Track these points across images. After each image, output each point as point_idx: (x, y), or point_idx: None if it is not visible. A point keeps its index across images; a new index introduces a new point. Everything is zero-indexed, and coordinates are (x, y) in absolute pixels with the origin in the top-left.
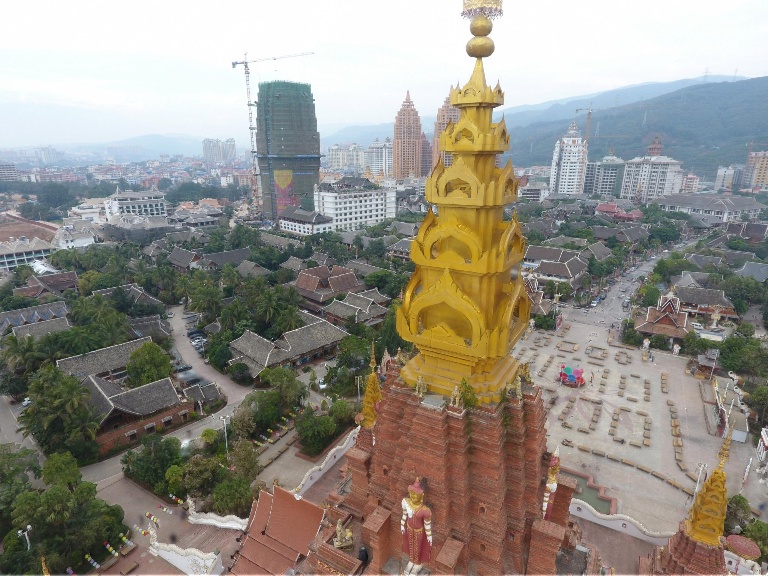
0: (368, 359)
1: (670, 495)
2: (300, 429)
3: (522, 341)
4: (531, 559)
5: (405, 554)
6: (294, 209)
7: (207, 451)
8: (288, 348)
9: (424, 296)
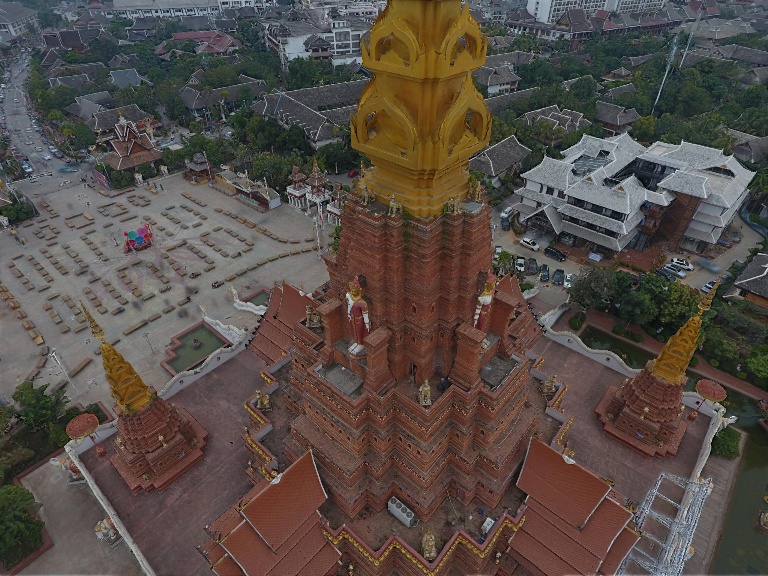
0: None
1: (303, 260)
2: None
3: (25, 245)
4: None
5: None
6: None
7: None
8: None
9: (453, 111)
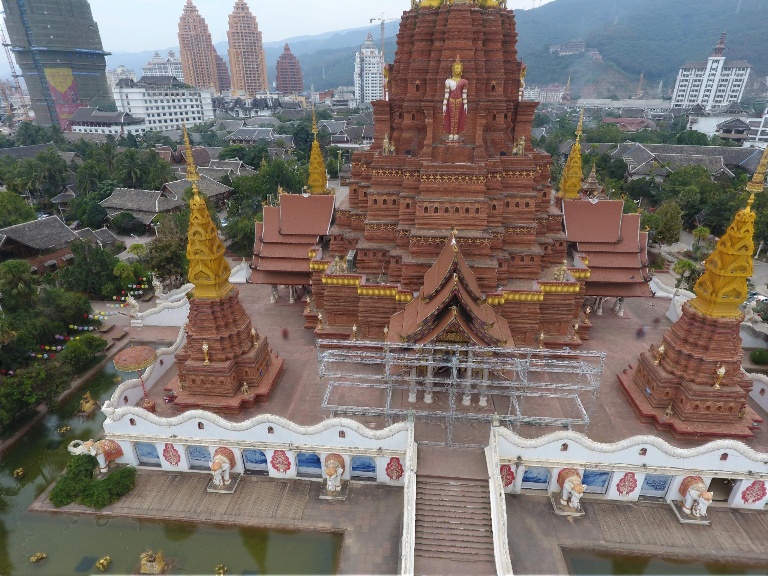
0: (260, 202)
1: None
2: (234, 232)
3: None
4: (516, 134)
5: (445, 134)
6: (90, 111)
7: (141, 264)
8: (174, 197)
9: None
